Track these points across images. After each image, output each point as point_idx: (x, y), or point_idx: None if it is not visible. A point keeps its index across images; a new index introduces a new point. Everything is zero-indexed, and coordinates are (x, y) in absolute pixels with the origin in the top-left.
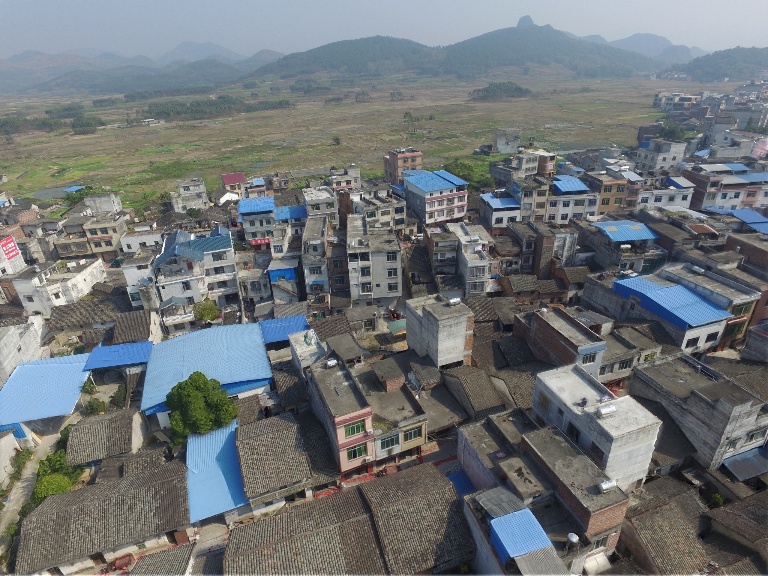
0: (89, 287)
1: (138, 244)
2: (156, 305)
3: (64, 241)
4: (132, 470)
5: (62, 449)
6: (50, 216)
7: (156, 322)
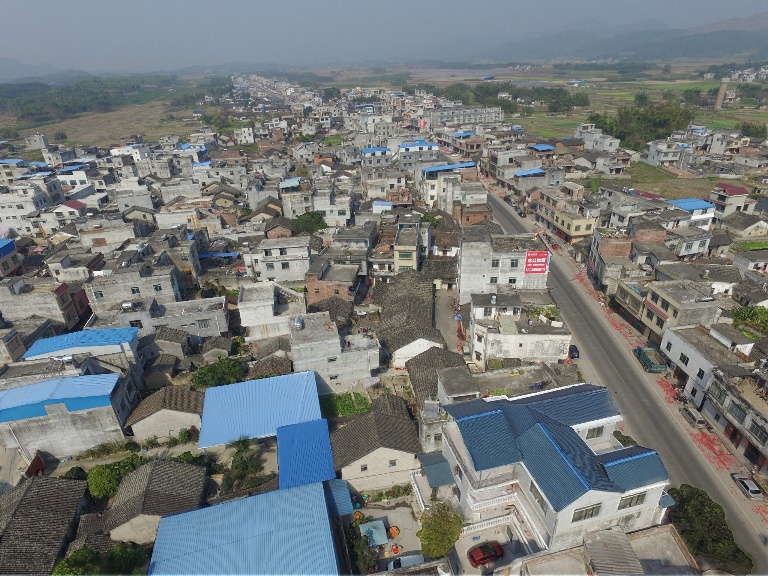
0: (523, 355)
1: (680, 353)
2: (424, 447)
3: (625, 286)
4: (74, 547)
5: (141, 464)
6: (764, 244)
7: (402, 464)
